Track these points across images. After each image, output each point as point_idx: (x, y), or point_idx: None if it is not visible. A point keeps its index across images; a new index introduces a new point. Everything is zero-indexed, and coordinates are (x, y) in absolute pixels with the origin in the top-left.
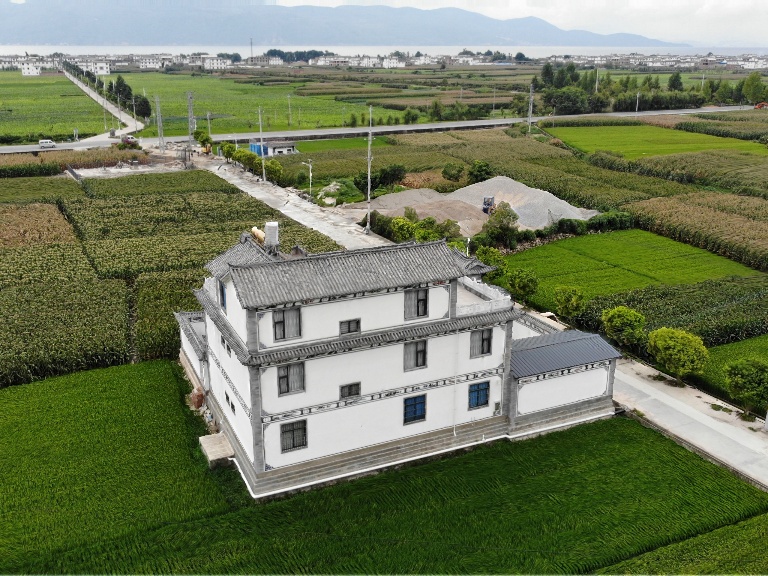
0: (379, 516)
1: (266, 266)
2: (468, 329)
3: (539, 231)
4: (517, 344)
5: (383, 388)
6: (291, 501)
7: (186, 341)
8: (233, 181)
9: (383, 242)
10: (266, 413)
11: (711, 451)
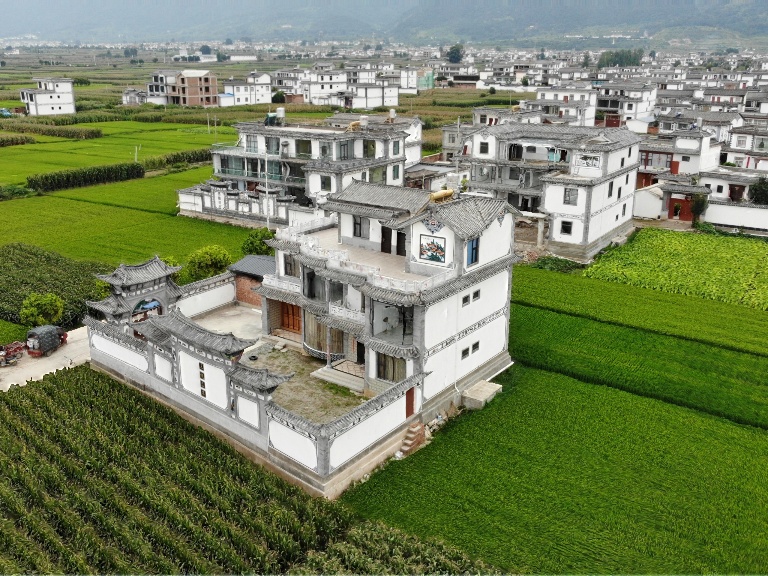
0: None
1: None
2: None
3: None
4: None
5: None
6: None
7: (356, 435)
8: None
9: None
10: None
11: None
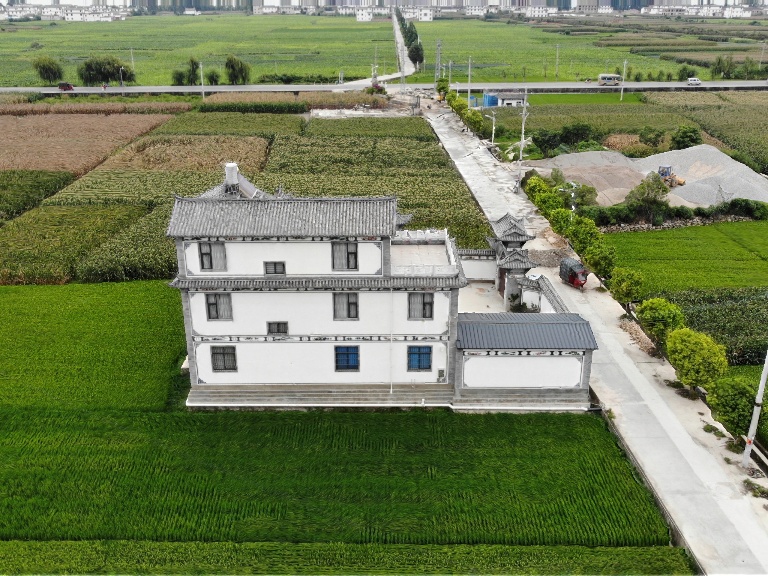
0: (264, 445)
1: (209, 202)
2: (405, 290)
3: (699, 209)
4: (494, 317)
5: (312, 332)
6: (209, 415)
7: None
8: (440, 130)
9: (524, 202)
10: (197, 333)
11: (649, 470)
